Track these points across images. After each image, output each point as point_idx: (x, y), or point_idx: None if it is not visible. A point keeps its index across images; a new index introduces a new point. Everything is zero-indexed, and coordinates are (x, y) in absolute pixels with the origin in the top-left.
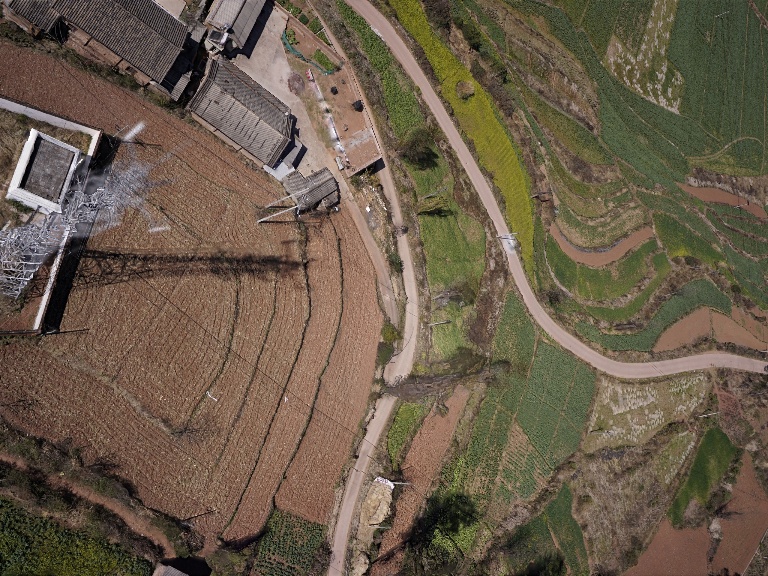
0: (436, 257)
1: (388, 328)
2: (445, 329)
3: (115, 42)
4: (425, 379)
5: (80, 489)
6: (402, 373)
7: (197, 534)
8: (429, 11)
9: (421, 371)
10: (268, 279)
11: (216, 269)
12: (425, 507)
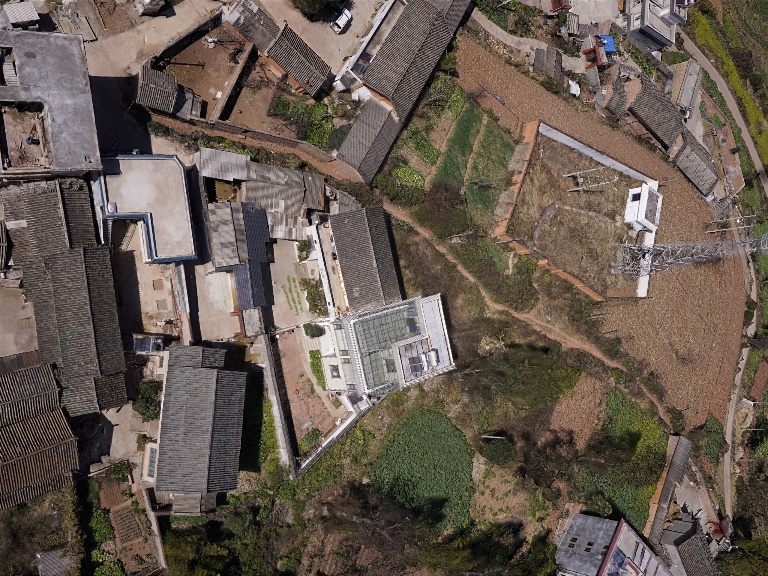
0: (759, 252)
1: (751, 301)
2: (766, 303)
3: (655, 125)
4: (759, 337)
5: (643, 388)
6: (751, 332)
7: (684, 420)
8: (736, 67)
9: (760, 331)
10: (710, 269)
11: (694, 262)
12: (756, 422)
